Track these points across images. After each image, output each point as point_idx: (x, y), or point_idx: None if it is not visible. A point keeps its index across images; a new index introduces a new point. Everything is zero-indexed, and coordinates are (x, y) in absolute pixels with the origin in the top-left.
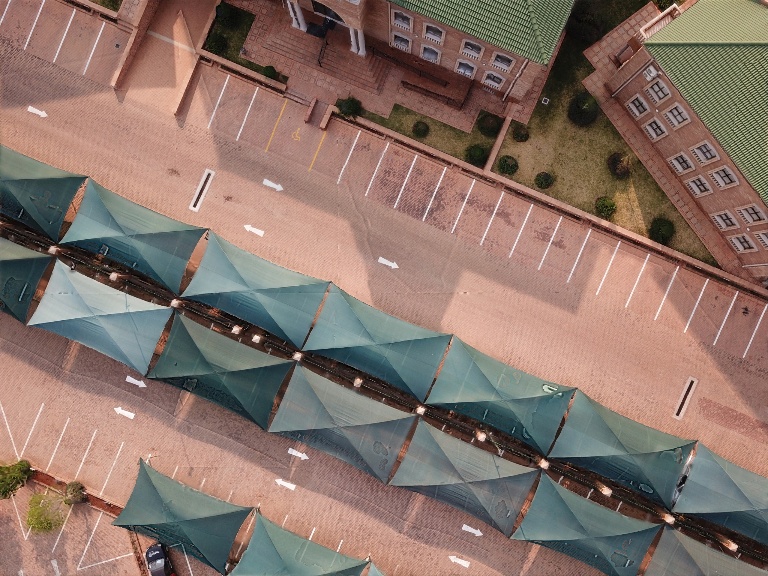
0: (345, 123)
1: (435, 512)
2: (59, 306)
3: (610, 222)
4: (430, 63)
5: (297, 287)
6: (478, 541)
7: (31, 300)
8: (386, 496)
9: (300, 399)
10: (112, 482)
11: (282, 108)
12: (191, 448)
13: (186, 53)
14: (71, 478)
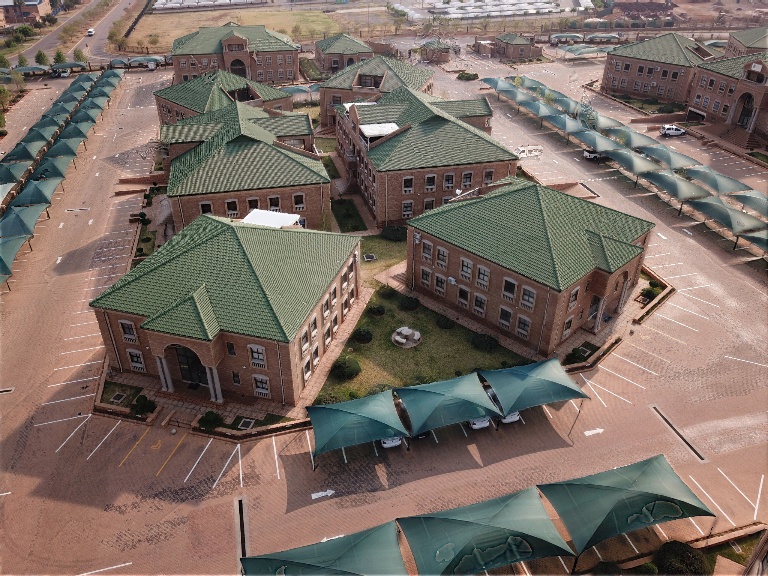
0: None
1: None
2: None
3: None
4: None
5: (24, 223)
6: None
7: None
8: None
9: None
10: None
11: None
12: None
13: None
14: None
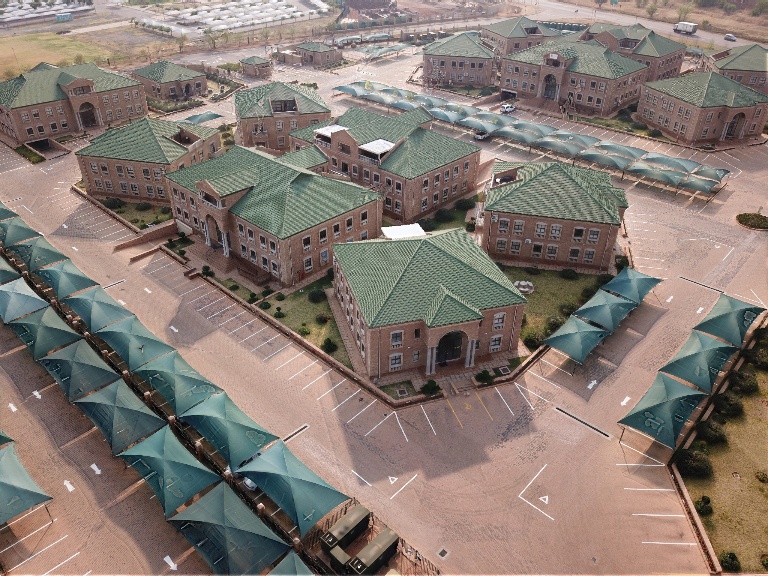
0: (202, 279)
1: (83, 450)
2: None
3: (302, 337)
4: (255, 266)
5: (116, 307)
6: (93, 477)
7: None
8: (63, 432)
9: (68, 349)
10: None
11: (179, 269)
12: None
13: None
14: None
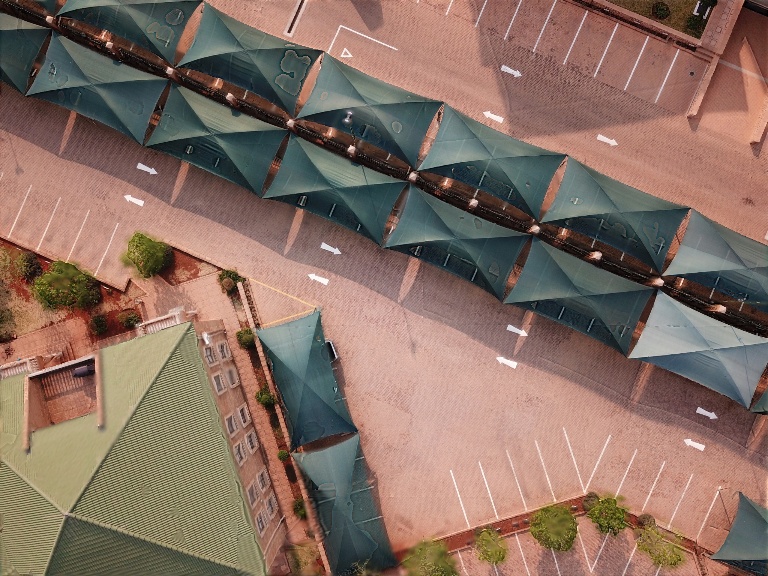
0: None
1: None
2: (669, 339)
3: None
4: None
5: None
6: None
7: (633, 332)
8: None
9: None
10: (680, 514)
11: None
12: (763, 480)
13: (755, 81)
14: (638, 510)
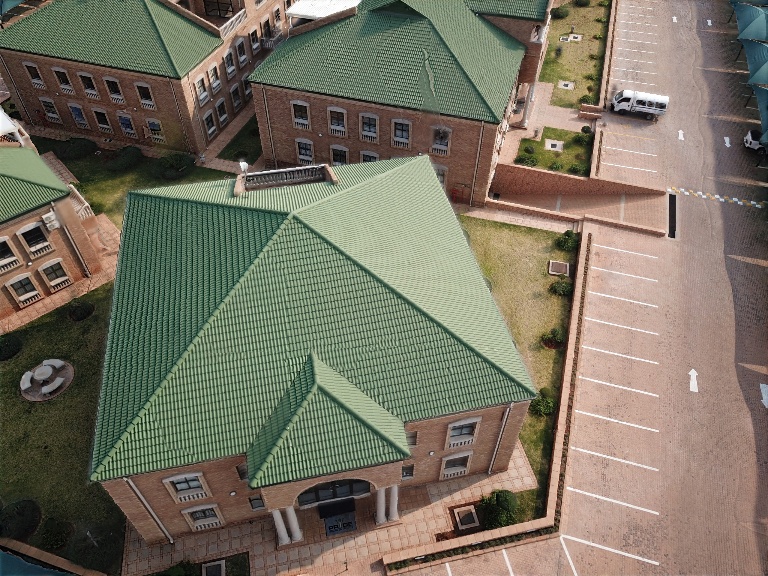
0: None
1: None
2: None
3: None
4: None
5: None
6: None
7: None
8: None
9: None
10: None
11: None
12: None
13: None
14: None
